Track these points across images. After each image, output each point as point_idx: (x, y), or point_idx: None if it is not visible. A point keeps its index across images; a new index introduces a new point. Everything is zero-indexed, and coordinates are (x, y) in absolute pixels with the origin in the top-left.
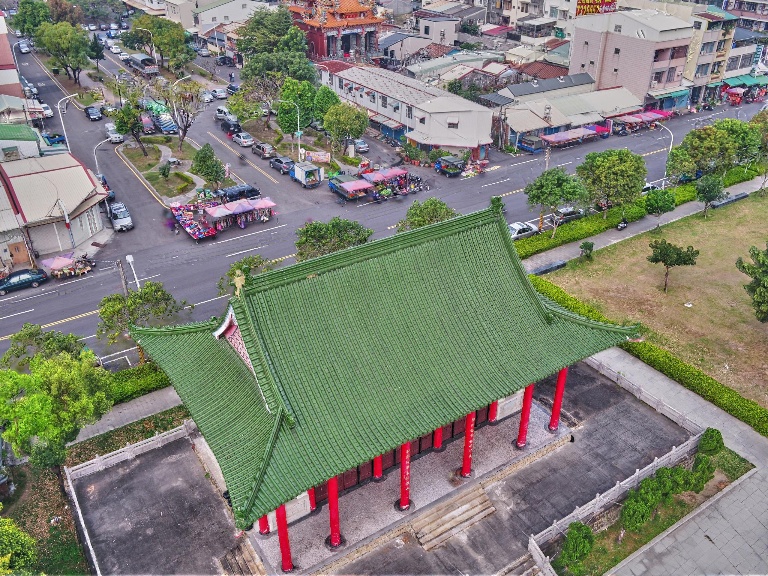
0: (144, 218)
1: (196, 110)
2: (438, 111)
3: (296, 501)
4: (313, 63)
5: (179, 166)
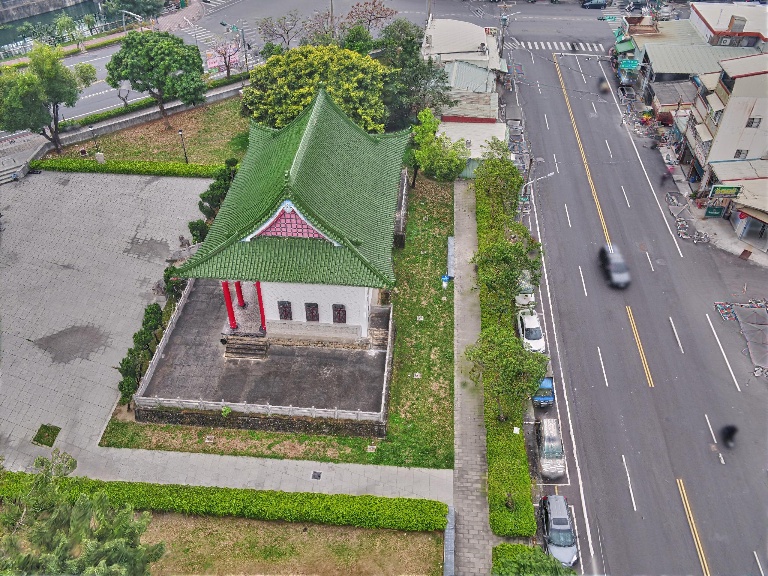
0: None
1: None
2: None
3: None
4: None
5: None
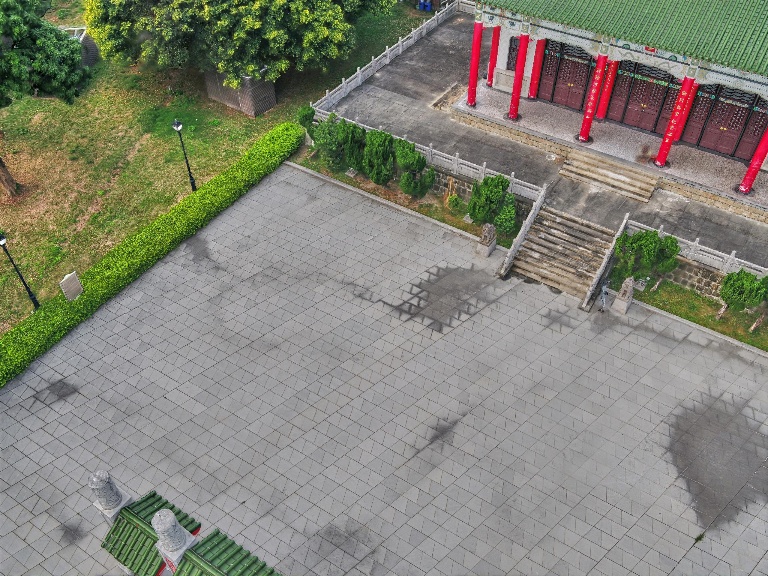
0: None
1: None
2: None
3: None
4: None
5: None
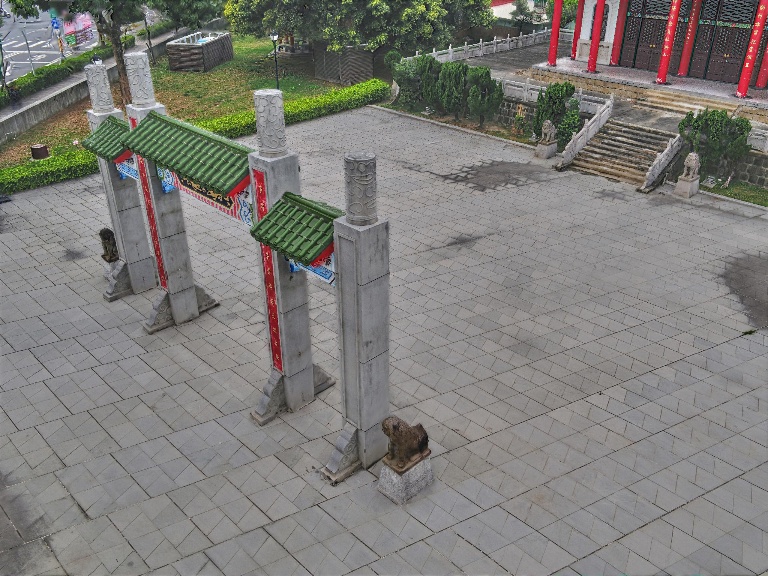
0: None
1: None
2: None
3: (602, 42)
4: None
5: None
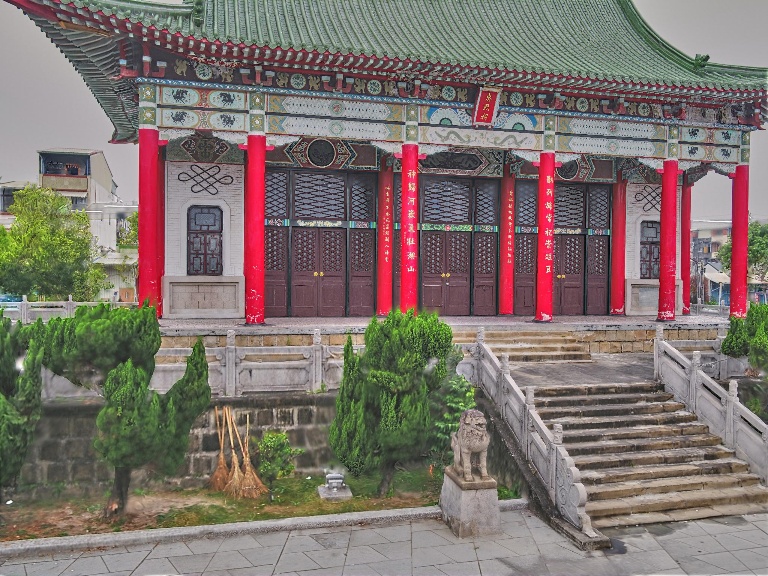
0: None
1: None
2: None
3: (219, 276)
4: None
5: None
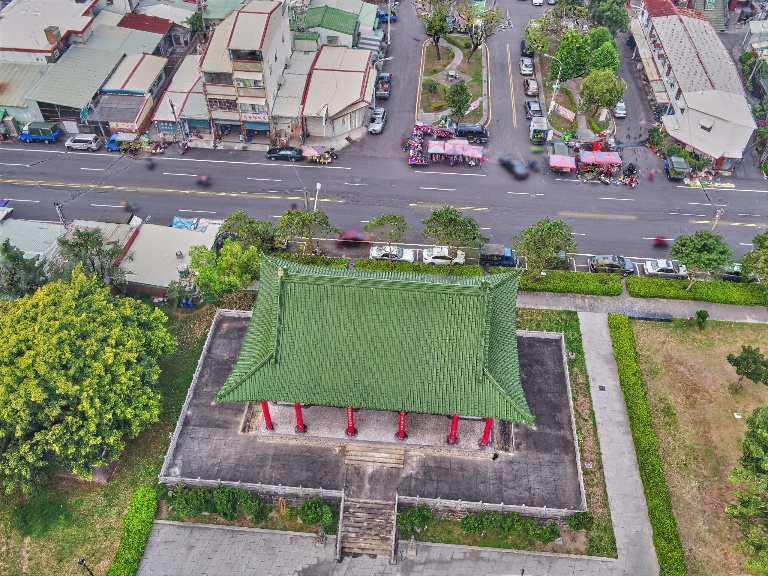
0: (395, 126)
1: (489, 33)
2: (697, 108)
3: None
4: (631, 3)
5: (455, 80)
